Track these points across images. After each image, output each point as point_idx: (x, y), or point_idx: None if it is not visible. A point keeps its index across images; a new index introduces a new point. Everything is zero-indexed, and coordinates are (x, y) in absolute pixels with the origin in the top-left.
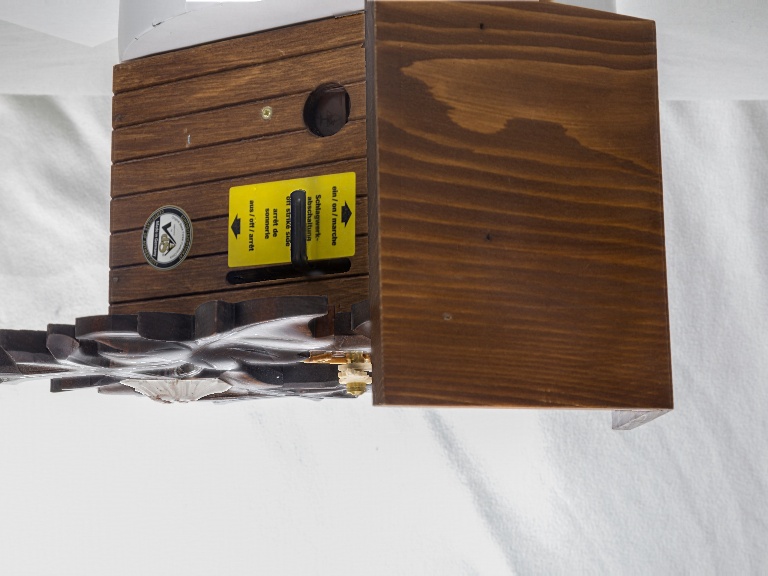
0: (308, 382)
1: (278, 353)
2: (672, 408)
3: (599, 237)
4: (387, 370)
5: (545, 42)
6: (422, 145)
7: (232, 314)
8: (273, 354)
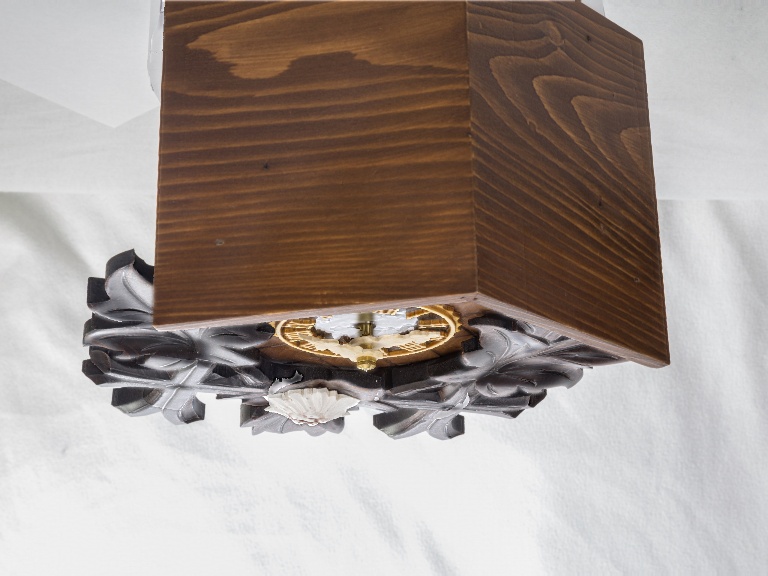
0: (411, 383)
1: (241, 332)
2: (475, 292)
3: (390, 143)
4: (157, 296)
5: None
6: (203, 102)
7: None
8: (240, 334)
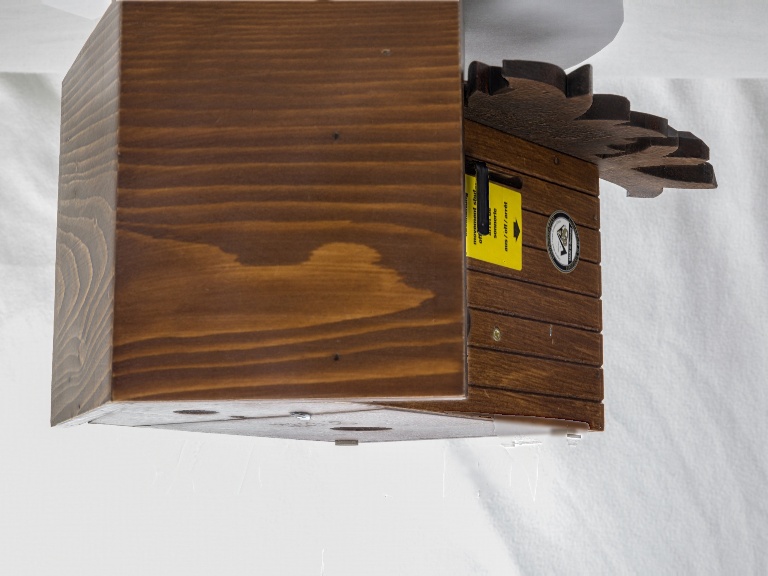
0: None
1: None
2: None
3: (202, 152)
4: None
5: (258, 353)
6: (411, 220)
7: (570, 87)
8: None
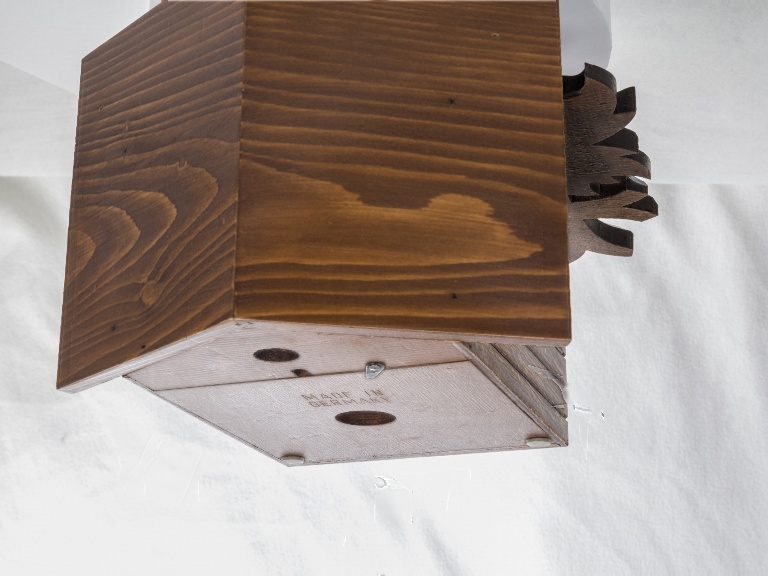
0: None
1: None
2: None
3: (325, 99)
4: None
5: (380, 285)
6: (521, 181)
7: None
8: None
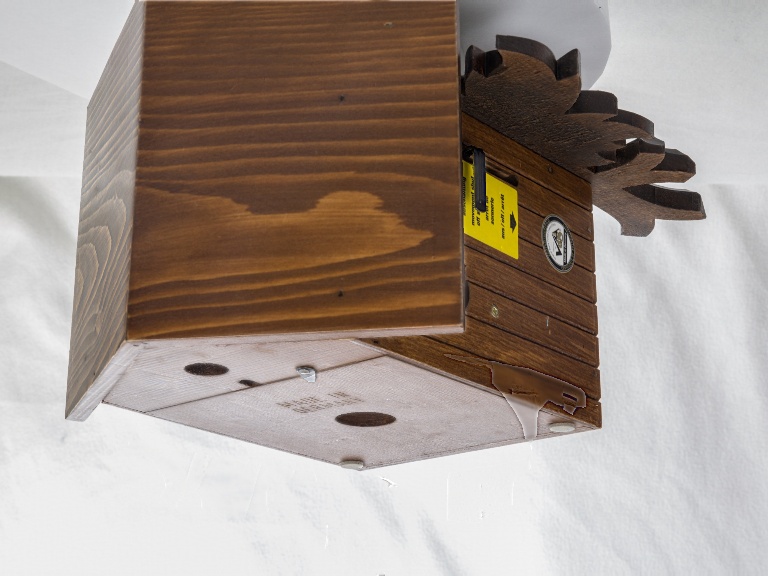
0: None
1: None
2: None
3: (217, 116)
4: None
5: (266, 292)
6: (412, 169)
7: (559, 71)
8: None
